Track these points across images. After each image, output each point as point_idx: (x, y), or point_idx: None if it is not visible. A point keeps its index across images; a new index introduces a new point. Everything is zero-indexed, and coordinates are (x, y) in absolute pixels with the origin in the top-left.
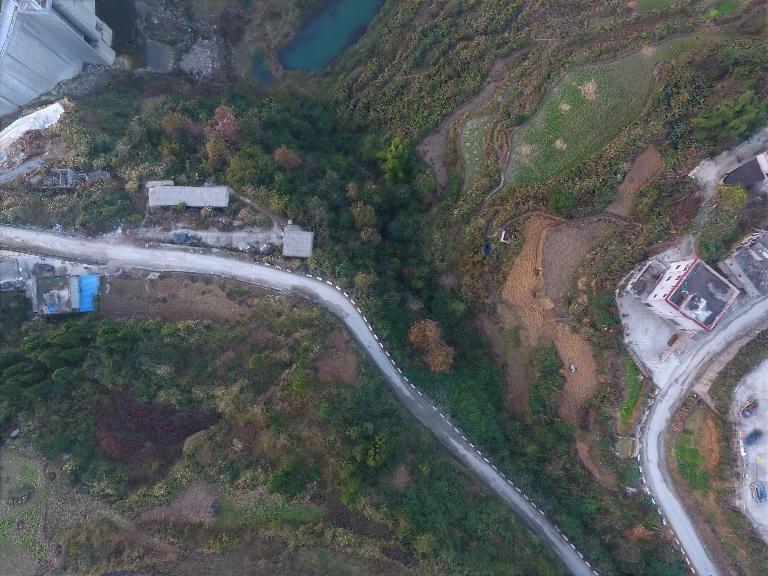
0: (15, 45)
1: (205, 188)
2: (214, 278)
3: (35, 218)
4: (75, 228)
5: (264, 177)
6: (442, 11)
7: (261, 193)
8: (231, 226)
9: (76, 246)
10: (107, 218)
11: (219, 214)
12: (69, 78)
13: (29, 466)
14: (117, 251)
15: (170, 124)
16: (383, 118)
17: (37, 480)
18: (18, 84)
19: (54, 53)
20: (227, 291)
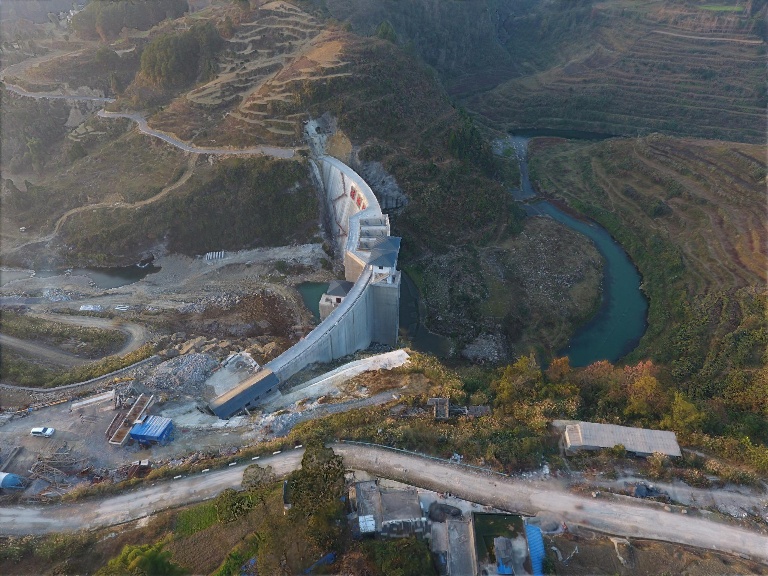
0: (358, 306)
1: (645, 430)
2: (724, 556)
3: (426, 443)
4: (486, 459)
5: (707, 428)
6: (737, 326)
7: (728, 442)
8: (709, 480)
9: (484, 485)
10: (526, 452)
11: (672, 465)
12: (362, 349)
13: None
14: (547, 498)
15: None
16: (743, 403)
17: None
18: (343, 338)
19: (366, 324)
20: None
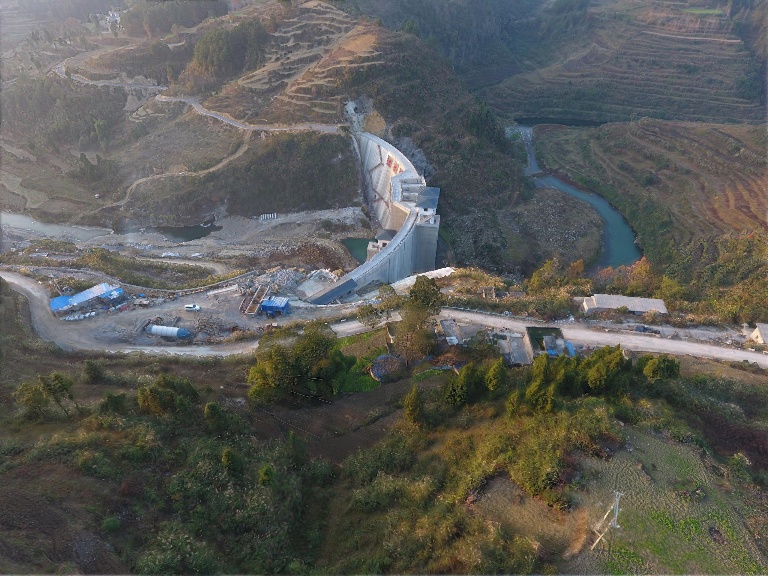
0: (408, 241)
1: (642, 298)
2: None
3: (484, 305)
4: (528, 313)
5: None
6: None
7: (701, 304)
8: (687, 322)
9: None
10: (557, 309)
11: None
12: None
13: (677, 454)
14: (574, 333)
15: (582, 266)
16: None
17: (698, 474)
18: (396, 266)
19: None
20: (729, 363)
